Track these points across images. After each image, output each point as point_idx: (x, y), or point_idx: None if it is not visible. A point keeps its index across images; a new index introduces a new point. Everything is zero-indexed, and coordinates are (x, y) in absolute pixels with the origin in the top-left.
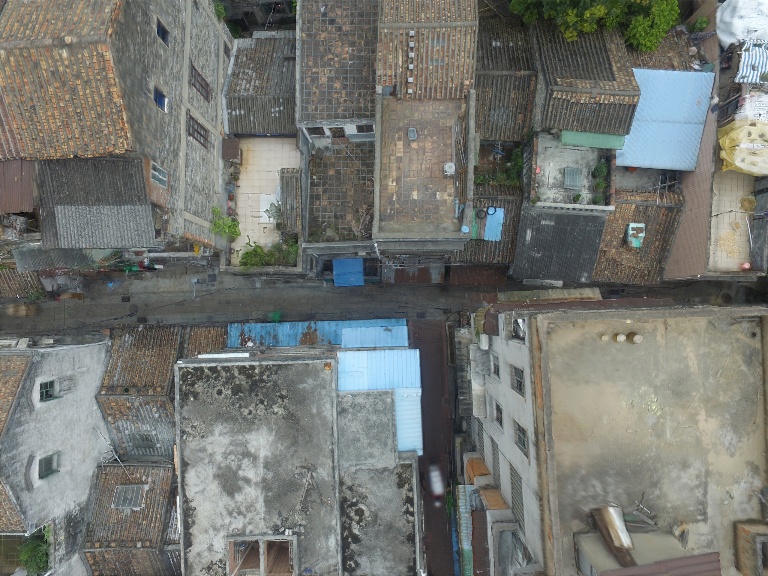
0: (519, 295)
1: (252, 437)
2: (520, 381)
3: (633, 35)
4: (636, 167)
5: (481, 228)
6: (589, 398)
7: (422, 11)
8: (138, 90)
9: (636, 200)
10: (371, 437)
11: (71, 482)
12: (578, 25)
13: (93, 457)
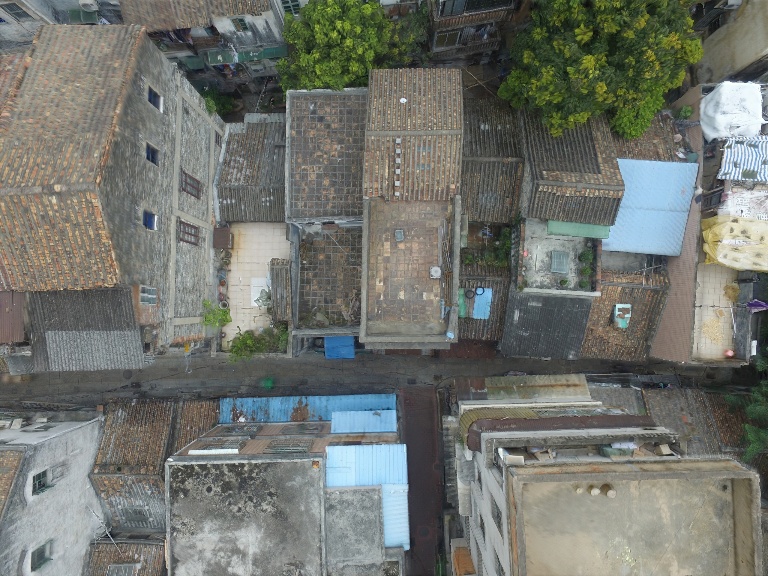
0: (506, 381)
1: (241, 534)
2: (499, 516)
3: (618, 125)
4: (622, 251)
5: (470, 307)
6: (564, 549)
7: (409, 116)
8: (127, 223)
9: (622, 282)
10: (358, 534)
11: (64, 566)
12: (563, 123)
13: (86, 536)
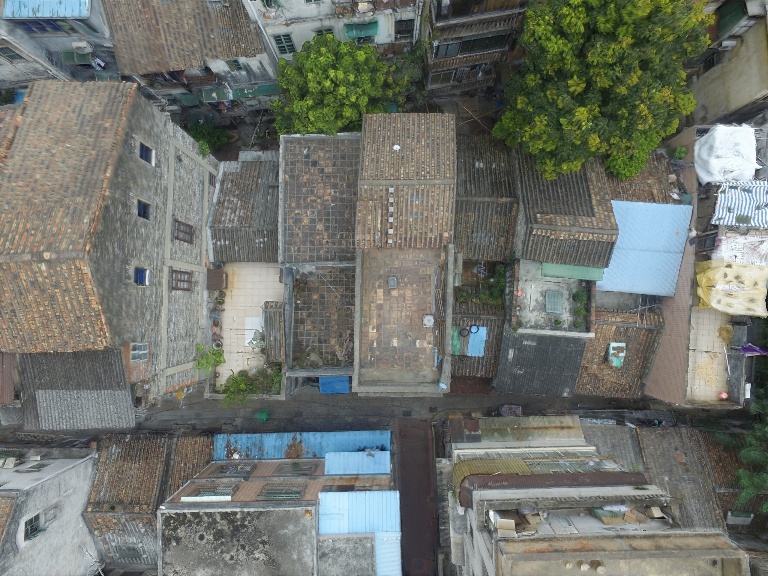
0: (500, 422)
1: None
2: None
3: (613, 166)
4: (616, 291)
5: (464, 345)
6: None
7: (402, 164)
8: (117, 284)
9: (617, 321)
10: None
11: None
12: None
13: (79, 575)
